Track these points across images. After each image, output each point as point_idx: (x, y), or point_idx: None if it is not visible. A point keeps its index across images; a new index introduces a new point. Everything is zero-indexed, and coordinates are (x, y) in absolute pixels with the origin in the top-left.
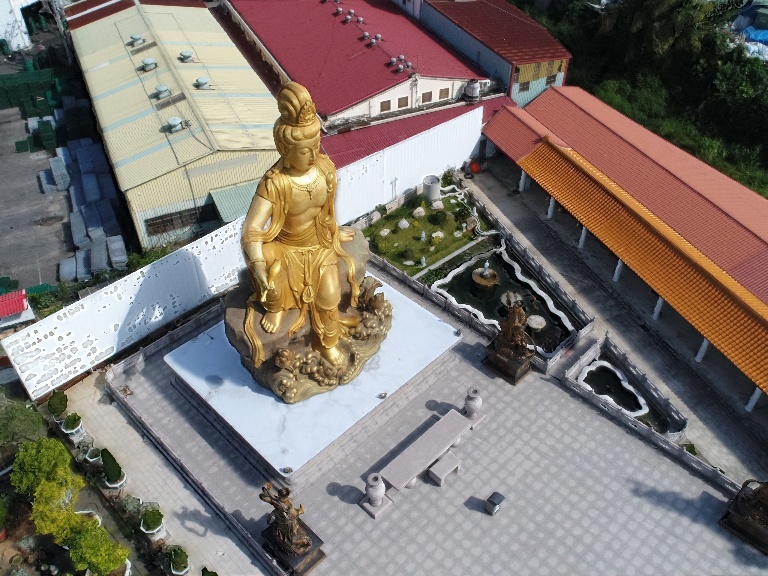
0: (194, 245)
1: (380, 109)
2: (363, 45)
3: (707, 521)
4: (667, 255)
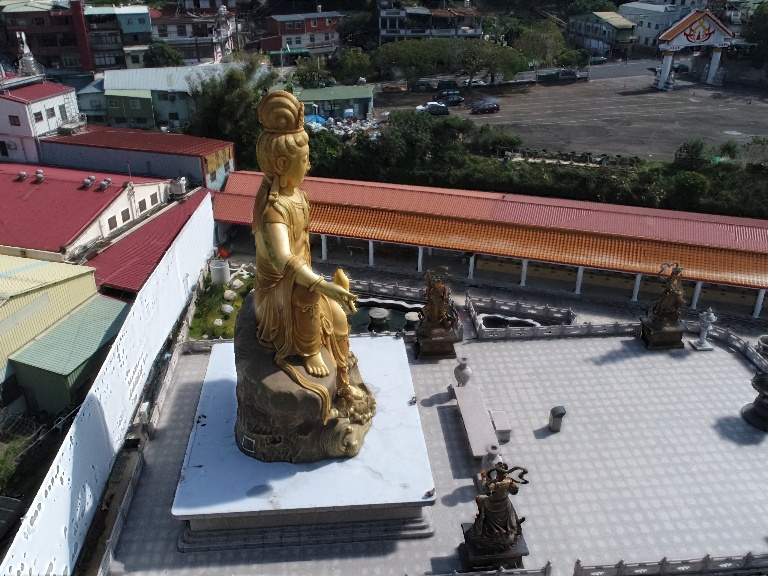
0: (96, 387)
1: (109, 228)
2: (28, 184)
3: (643, 353)
4: (457, 226)
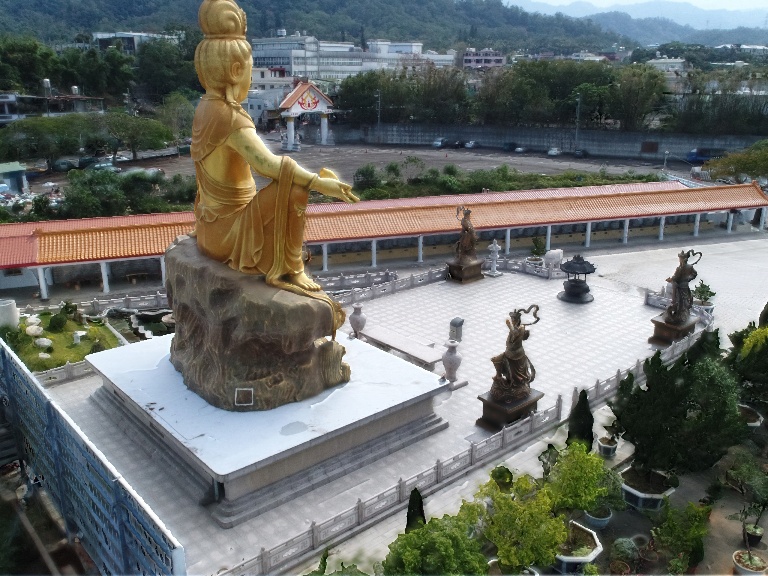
0: None
1: None
2: None
3: None
4: None
